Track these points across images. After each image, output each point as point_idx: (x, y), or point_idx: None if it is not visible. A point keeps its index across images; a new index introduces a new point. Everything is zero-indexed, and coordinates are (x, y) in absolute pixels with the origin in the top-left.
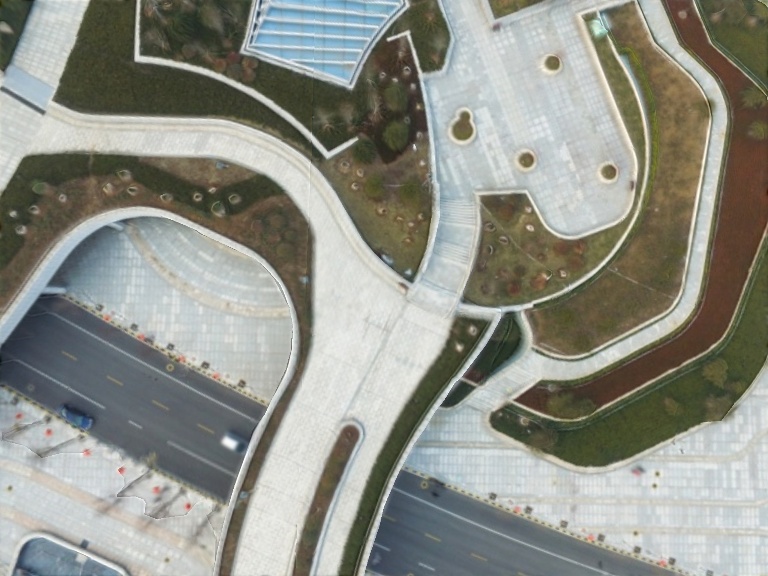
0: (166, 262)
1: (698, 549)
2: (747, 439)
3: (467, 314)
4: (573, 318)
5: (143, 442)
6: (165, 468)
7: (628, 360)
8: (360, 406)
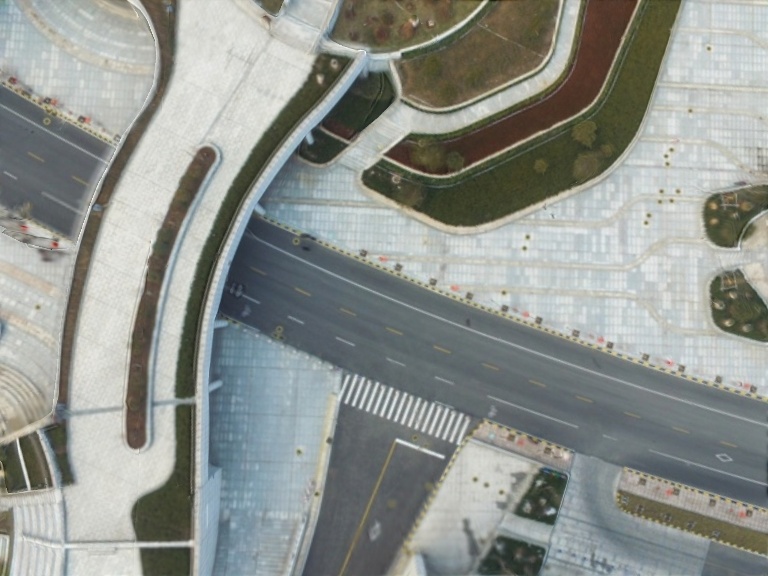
0: (46, 19)
1: (565, 309)
2: (618, 206)
3: (330, 51)
4: (442, 71)
5: (17, 193)
6: (39, 218)
7: (498, 118)
8: (219, 132)
